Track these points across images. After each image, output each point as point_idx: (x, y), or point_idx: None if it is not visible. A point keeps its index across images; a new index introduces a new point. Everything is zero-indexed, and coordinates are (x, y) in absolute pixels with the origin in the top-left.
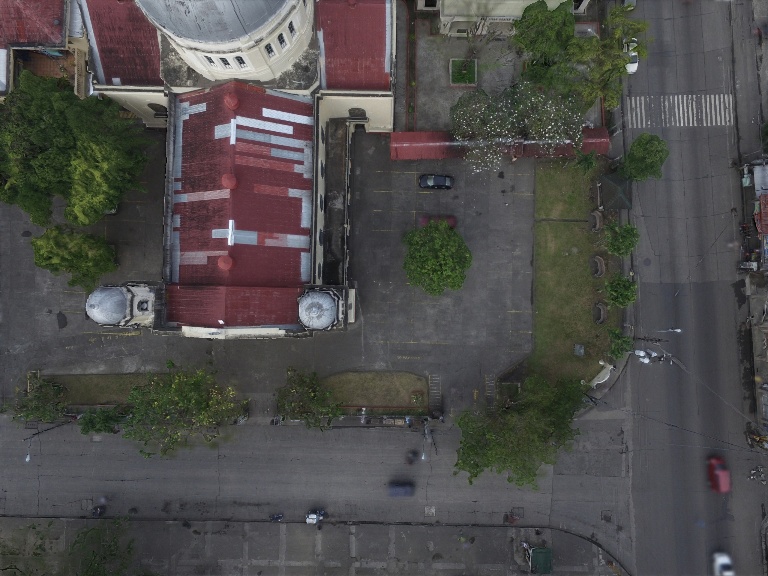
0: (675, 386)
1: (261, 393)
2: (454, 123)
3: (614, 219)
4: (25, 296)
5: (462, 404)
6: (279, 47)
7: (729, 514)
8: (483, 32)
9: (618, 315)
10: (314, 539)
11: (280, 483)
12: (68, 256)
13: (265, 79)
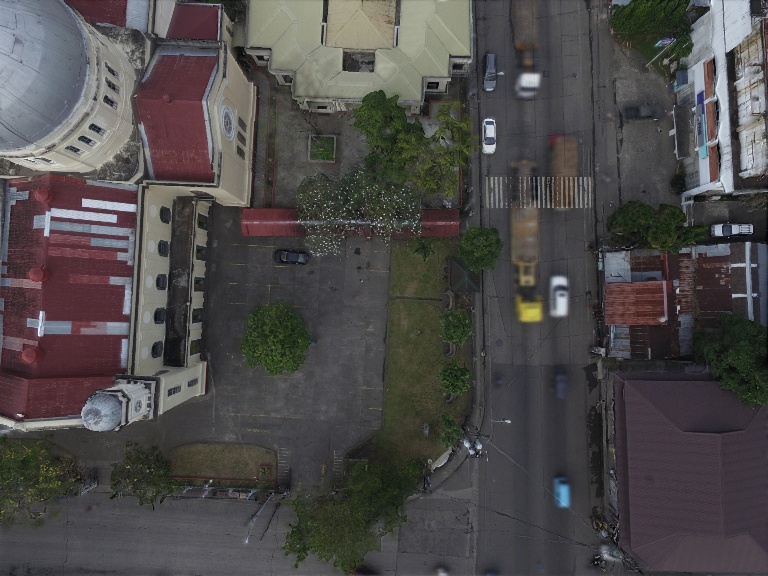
0: None
1: (112, 461)
2: (299, 205)
3: (468, 299)
4: None
5: (310, 479)
6: (86, 146)
7: None
8: (343, 109)
9: (469, 395)
10: None
11: (127, 551)
12: None
13: (84, 171)
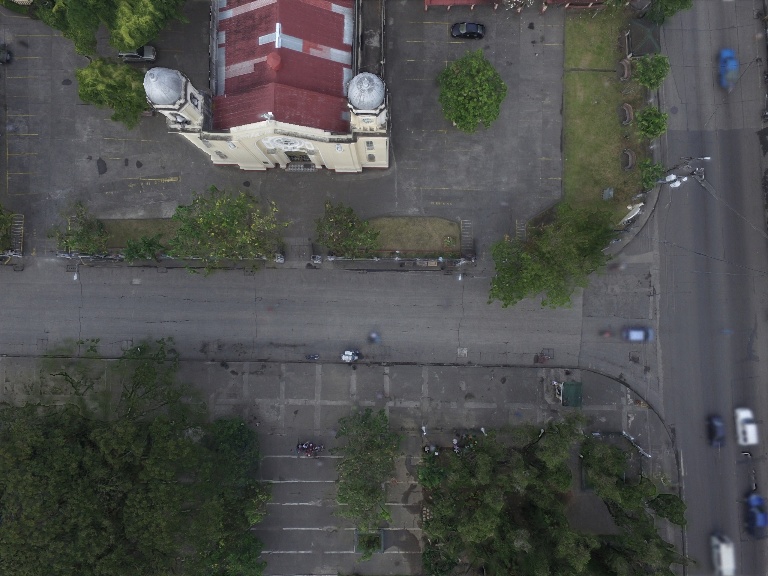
0: (701, 230)
1: (297, 238)
2: None
3: None
4: (66, 143)
5: (493, 248)
6: None
7: (754, 355)
8: None
9: None
10: (349, 379)
11: (316, 325)
12: (113, 81)
13: None
